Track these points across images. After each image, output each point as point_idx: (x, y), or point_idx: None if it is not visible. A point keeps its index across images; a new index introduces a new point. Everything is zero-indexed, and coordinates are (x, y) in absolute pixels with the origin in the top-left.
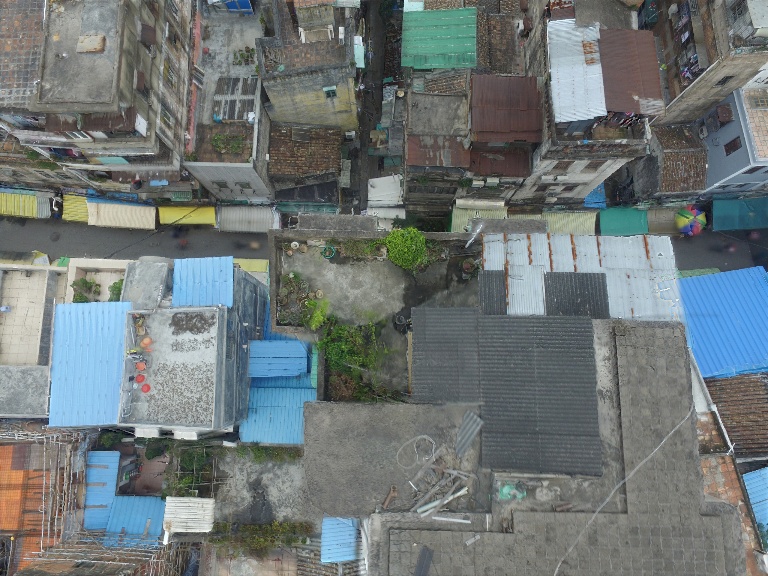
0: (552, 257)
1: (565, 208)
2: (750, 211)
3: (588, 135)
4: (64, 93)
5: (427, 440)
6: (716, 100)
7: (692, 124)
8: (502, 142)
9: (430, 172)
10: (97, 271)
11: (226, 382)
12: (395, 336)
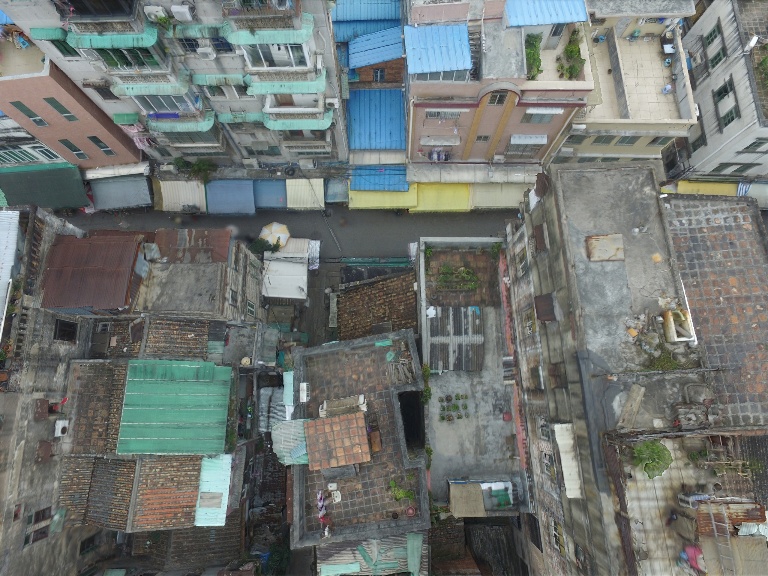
0: None
1: None
2: None
3: None
4: (623, 182)
5: None
6: None
7: None
8: None
9: None
10: None
11: None
12: None
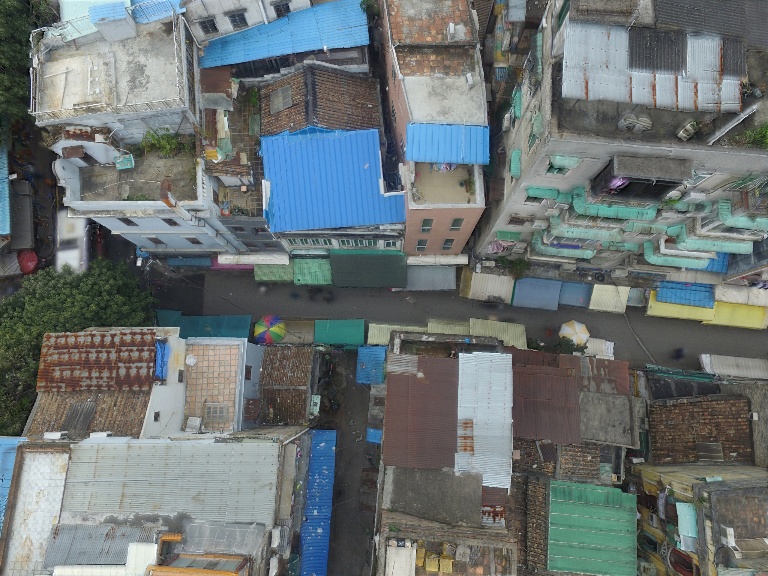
0: (676, 89)
1: None
2: None
3: None
4: None
5: None
6: None
7: None
8: None
9: None
10: None
11: None
12: (760, 83)
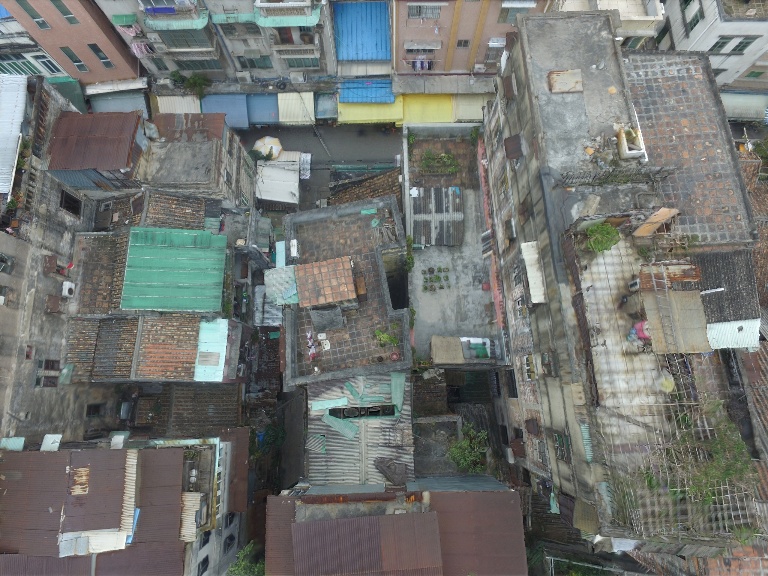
0: None
1: None
2: None
3: None
4: (583, 28)
5: None
6: None
7: None
8: None
9: None
10: None
11: None
12: None
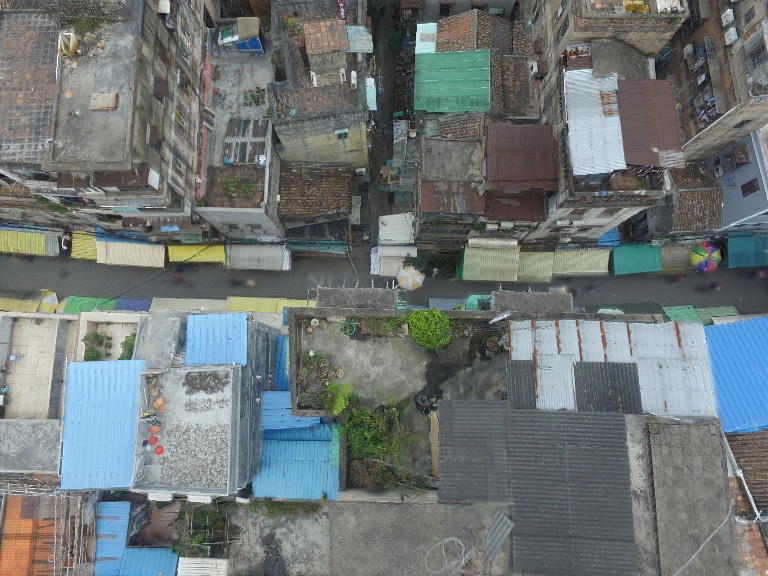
0: (581, 346)
1: (578, 246)
2: (766, 248)
3: (606, 186)
4: (77, 152)
5: (456, 542)
6: (732, 141)
7: (707, 161)
8: (517, 189)
9: (443, 216)
10: (108, 323)
11: (240, 443)
12: (417, 416)
